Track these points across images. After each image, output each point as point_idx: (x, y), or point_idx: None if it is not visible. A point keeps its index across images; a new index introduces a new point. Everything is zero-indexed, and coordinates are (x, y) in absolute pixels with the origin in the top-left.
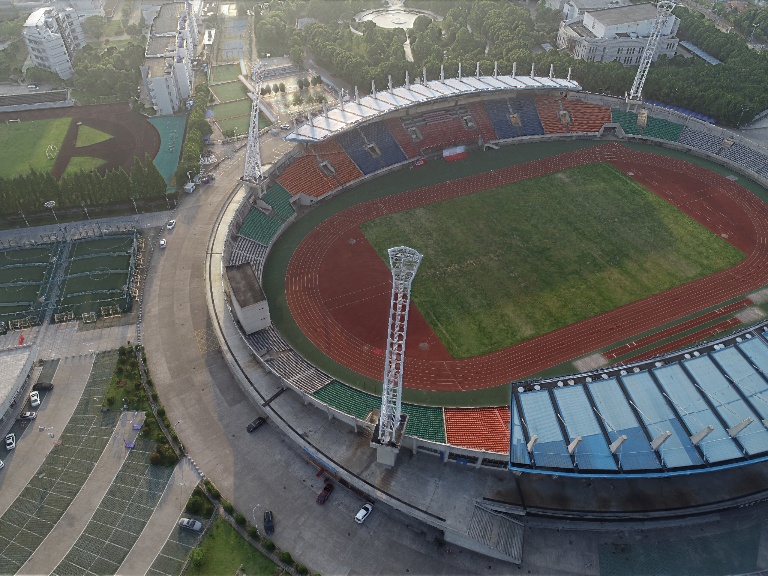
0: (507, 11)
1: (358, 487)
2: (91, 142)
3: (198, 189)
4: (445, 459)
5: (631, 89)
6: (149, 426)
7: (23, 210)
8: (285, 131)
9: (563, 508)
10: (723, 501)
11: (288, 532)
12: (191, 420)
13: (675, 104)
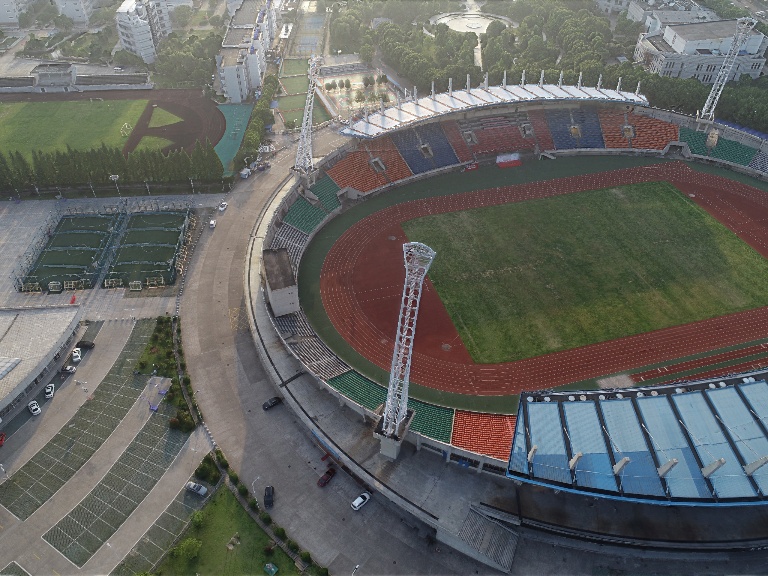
0: (585, 21)
1: (358, 475)
2: (163, 124)
3: (253, 175)
4: (447, 459)
5: (703, 108)
6: (173, 392)
7: (92, 181)
8: (344, 126)
9: (560, 524)
10: (733, 541)
11: (286, 509)
12: (213, 392)
13: (752, 127)
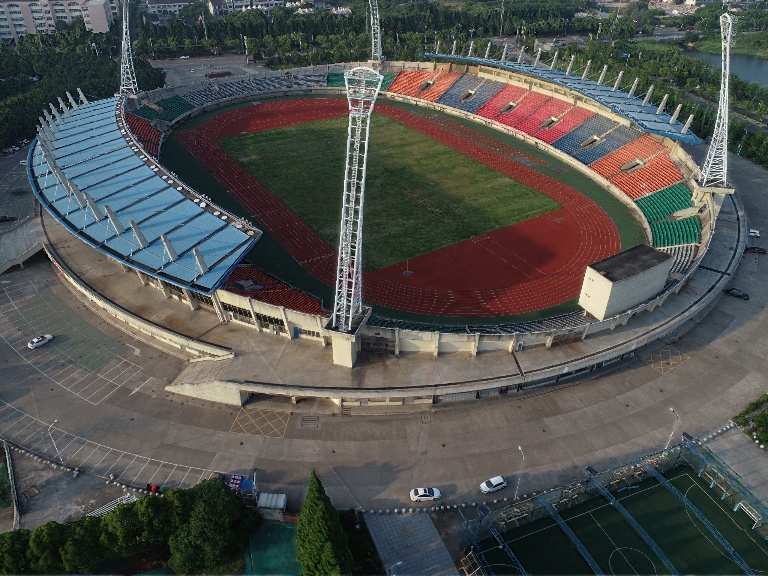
0: None
1: None
2: None
3: None
4: None
5: (121, 87)
6: None
7: None
8: (1, 401)
9: None
10: None
11: None
12: None
13: None
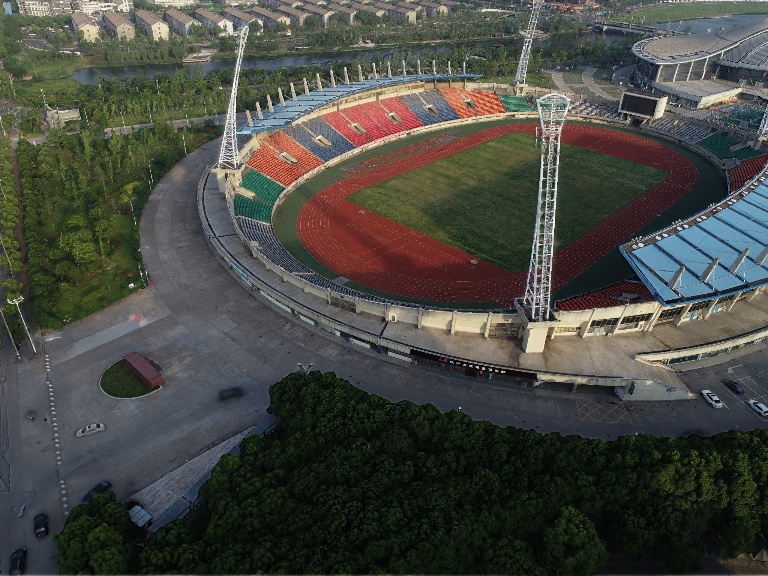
0: None
1: None
2: None
3: None
4: None
5: None
6: None
7: None
8: None
9: None
10: None
11: None
12: None
13: None
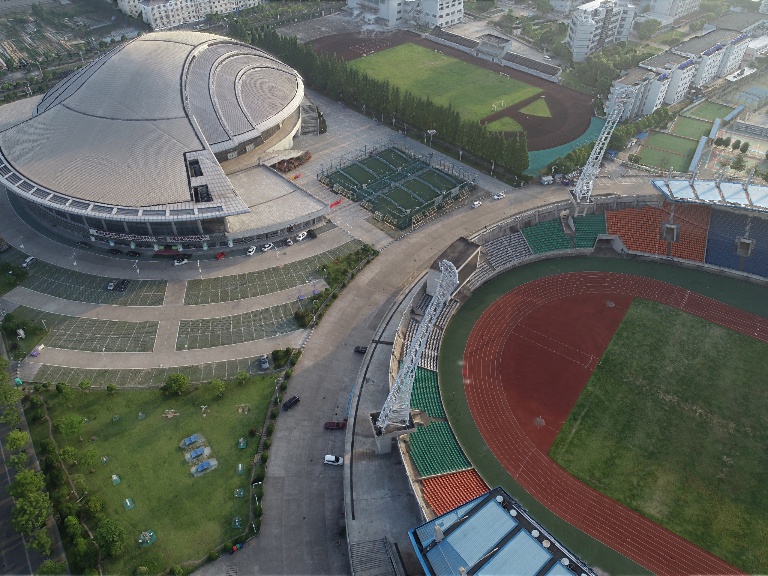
0: None
1: None
2: (532, 113)
3: (553, 185)
4: None
5: None
6: (320, 297)
7: None
8: None
9: None
10: None
11: (291, 420)
12: (341, 314)
13: None
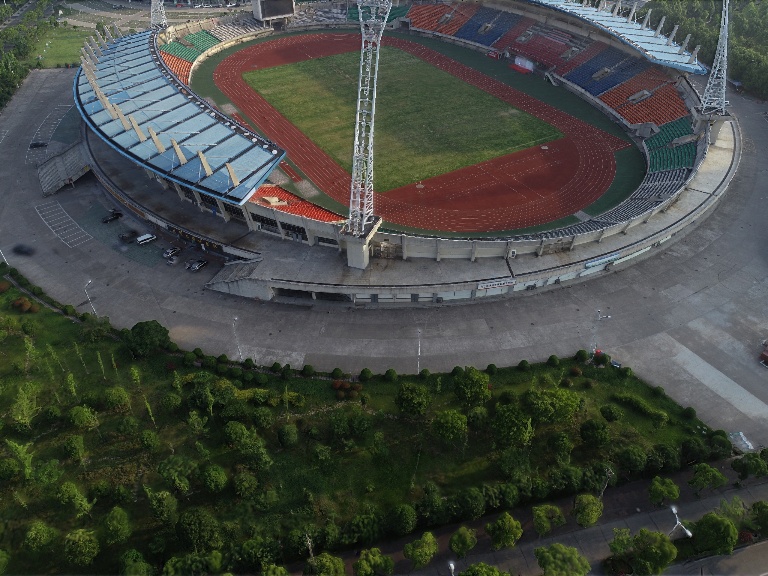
0: None
1: None
2: None
3: None
4: None
5: None
6: None
7: None
8: None
9: None
10: None
11: None
12: None
13: None
